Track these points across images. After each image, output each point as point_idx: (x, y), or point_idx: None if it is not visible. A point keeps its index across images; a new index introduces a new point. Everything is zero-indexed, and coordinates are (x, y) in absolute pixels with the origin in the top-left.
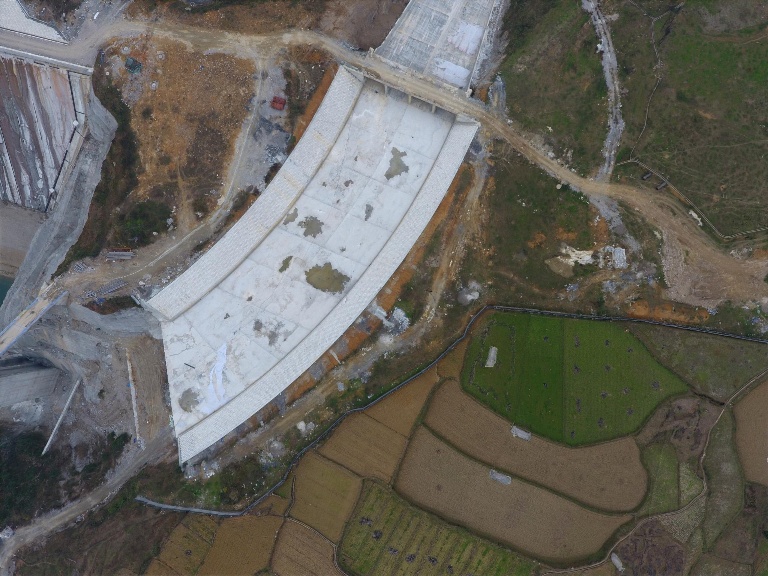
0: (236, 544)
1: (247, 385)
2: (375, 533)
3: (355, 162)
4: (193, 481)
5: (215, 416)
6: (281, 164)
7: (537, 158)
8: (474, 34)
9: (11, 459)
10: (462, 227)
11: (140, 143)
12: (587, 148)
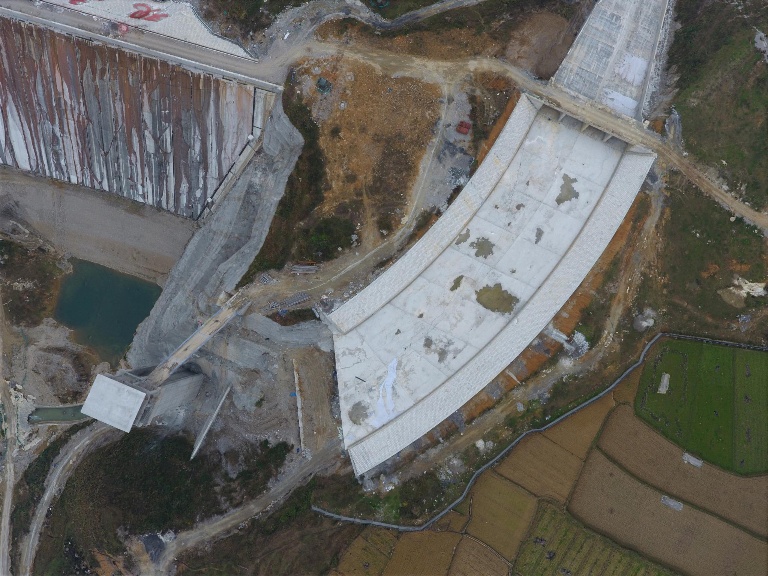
0: (414, 559)
1: (416, 400)
2: (549, 553)
3: (527, 186)
4: (371, 494)
5: (386, 430)
6: (463, 186)
7: (712, 190)
8: (639, 66)
9: (163, 463)
10: (639, 255)
11: (327, 160)
12: (761, 183)
